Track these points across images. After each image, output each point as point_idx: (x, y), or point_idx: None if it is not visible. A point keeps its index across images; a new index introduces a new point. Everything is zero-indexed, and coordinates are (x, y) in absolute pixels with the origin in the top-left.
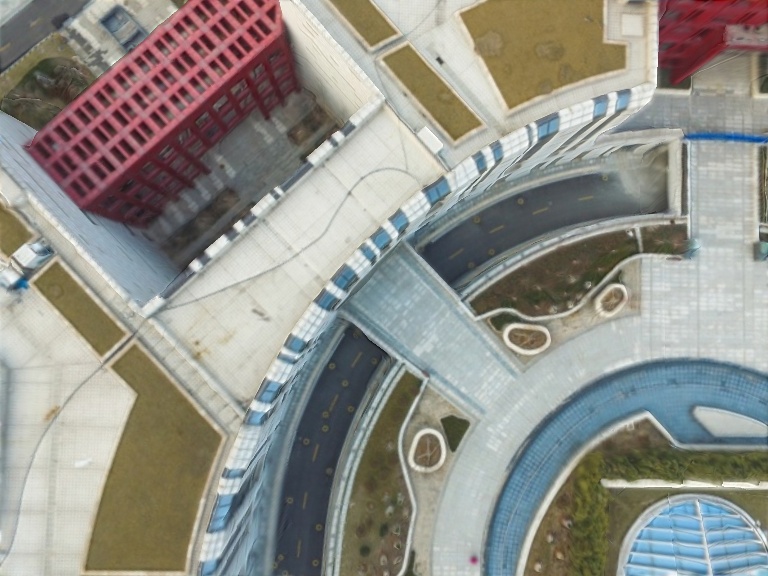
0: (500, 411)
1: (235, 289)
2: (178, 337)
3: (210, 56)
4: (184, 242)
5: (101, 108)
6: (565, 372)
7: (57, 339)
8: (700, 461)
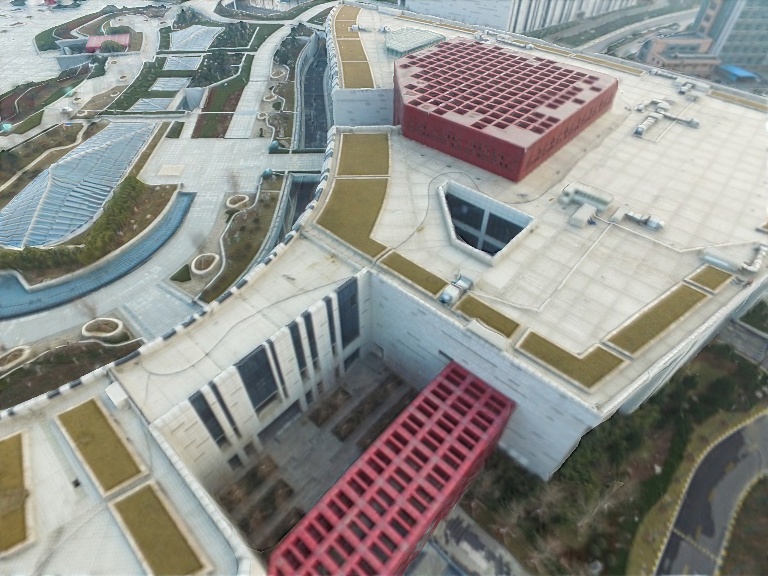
0: (144, 286)
1: (307, 290)
2: (346, 264)
3: (353, 514)
4: (403, 401)
5: (456, 444)
6: (81, 310)
7: (426, 260)
8: (5, 257)
